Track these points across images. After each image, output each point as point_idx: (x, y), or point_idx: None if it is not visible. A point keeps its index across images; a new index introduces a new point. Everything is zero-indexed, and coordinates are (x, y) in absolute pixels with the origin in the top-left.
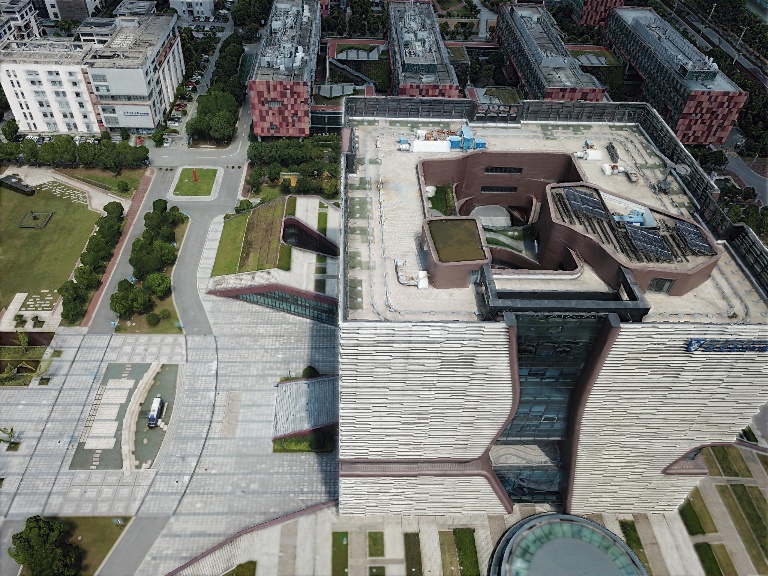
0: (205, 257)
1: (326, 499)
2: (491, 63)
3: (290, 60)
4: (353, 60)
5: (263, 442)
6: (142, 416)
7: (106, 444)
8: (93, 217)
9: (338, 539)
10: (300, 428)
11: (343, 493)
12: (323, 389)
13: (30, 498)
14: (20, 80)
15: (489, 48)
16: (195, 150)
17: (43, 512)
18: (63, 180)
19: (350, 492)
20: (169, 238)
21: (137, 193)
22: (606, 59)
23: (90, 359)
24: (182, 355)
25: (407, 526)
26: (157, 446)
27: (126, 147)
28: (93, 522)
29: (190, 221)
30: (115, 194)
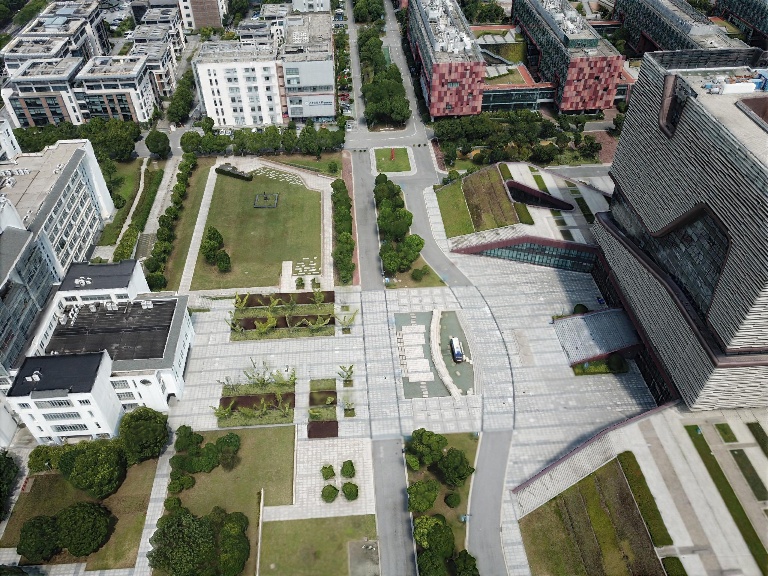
0: (433, 222)
1: (641, 409)
2: (617, 39)
3: (462, 44)
4: (492, 44)
5: (562, 368)
6: (444, 354)
7: (427, 377)
8: (315, 195)
9: (692, 431)
10: (594, 354)
11: (708, 386)
12: (601, 321)
13: (384, 422)
14: (218, 78)
15: (612, 25)
16: (377, 133)
17: (402, 432)
18: (272, 166)
19: (715, 384)
20: (400, 207)
21: (344, 173)
22: (727, 28)
23: (376, 311)
24: (455, 303)
25: (746, 418)
26: (470, 377)
27: (327, 132)
28: (449, 438)
29: (404, 193)
30: (325, 174)
